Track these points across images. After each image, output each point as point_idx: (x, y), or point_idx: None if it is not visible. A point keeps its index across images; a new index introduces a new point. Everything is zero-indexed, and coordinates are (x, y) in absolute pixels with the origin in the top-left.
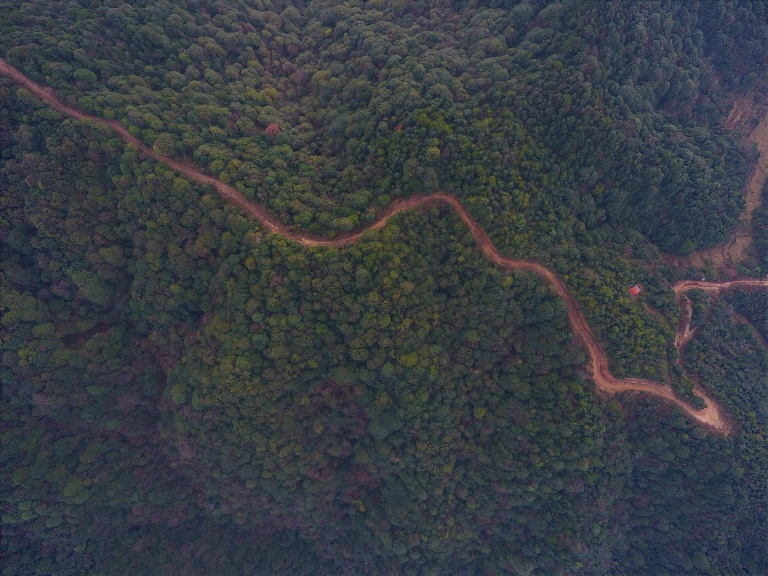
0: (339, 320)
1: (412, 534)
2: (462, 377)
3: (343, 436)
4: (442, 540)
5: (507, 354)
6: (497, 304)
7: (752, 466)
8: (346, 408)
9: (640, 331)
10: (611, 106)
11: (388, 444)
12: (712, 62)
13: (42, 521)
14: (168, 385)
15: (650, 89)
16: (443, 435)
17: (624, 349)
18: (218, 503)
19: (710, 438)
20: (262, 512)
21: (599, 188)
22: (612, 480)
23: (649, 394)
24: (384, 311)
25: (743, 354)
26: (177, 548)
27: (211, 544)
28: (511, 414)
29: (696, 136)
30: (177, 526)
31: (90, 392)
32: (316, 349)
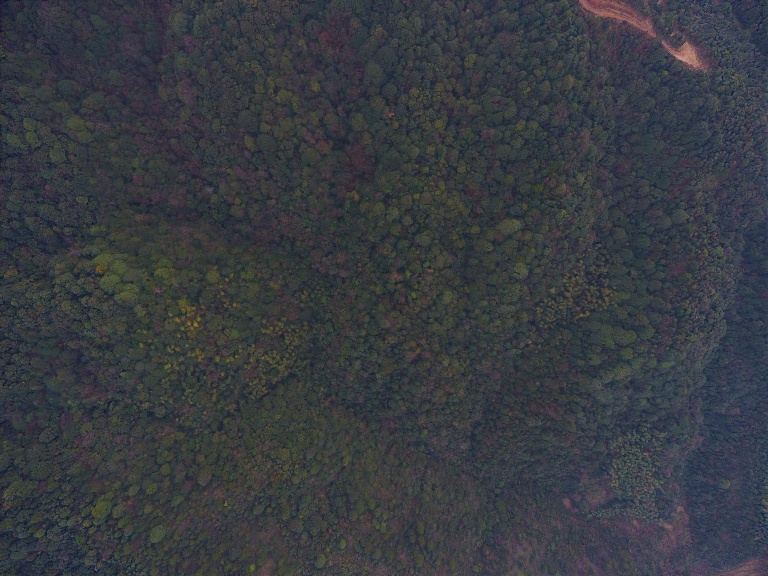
0: None
1: (405, 195)
2: (454, 24)
3: (339, 104)
4: (433, 196)
5: None
6: None
7: (727, 100)
8: (342, 62)
9: None
10: None
11: (382, 98)
12: None
13: (46, 150)
14: None
15: None
16: (435, 83)
17: None
18: (216, 186)
19: (688, 73)
20: (259, 202)
21: None
22: (596, 124)
23: (631, 25)
24: None
25: None
26: (176, 227)
27: (209, 236)
28: (500, 47)
29: None
30: (176, 214)
31: (93, 21)
32: None
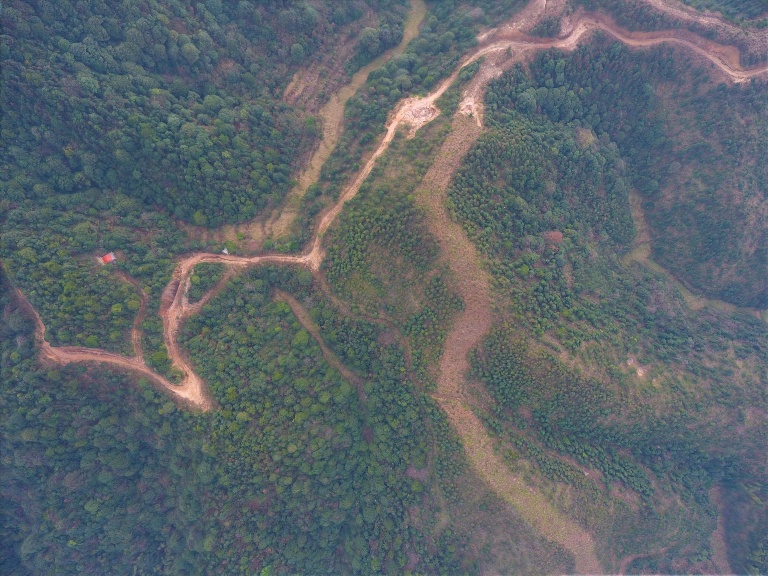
0: None
1: None
2: None
3: None
4: None
5: None
6: None
7: (226, 444)
8: None
9: (66, 297)
10: (53, 63)
11: None
12: (249, 31)
13: None
14: None
15: (124, 50)
16: None
17: (46, 314)
18: None
19: (184, 413)
20: None
21: (65, 150)
22: (98, 455)
23: (114, 365)
24: None
25: (265, 331)
26: None
27: None
28: None
29: (206, 104)
30: None
31: None
32: None
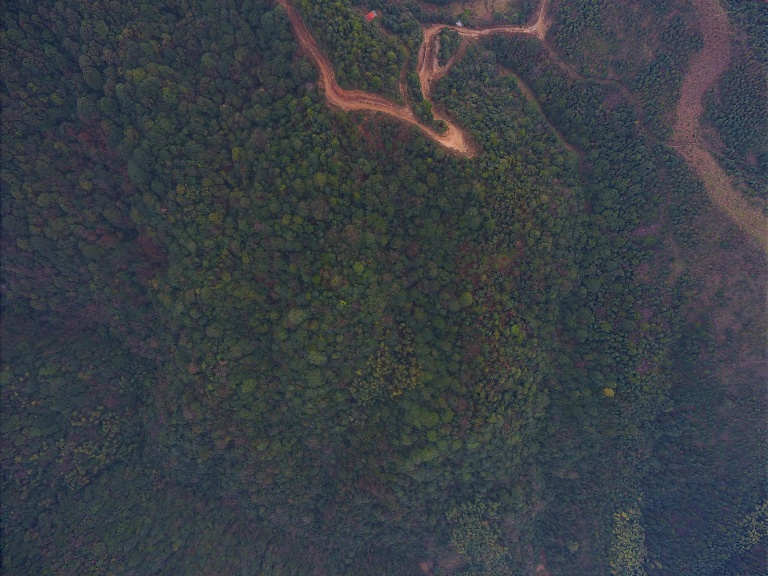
0: (61, 34)
1: (187, 290)
2: (215, 118)
3: (118, 199)
4: (214, 291)
5: (251, 85)
6: (216, 13)
7: (494, 185)
8: (109, 160)
9: None
10: None
11: (152, 194)
12: None
13: None
14: None
15: None
16: (202, 178)
17: (341, 51)
18: (9, 283)
19: (452, 159)
20: (58, 295)
21: None
22: (367, 213)
23: (387, 114)
24: (96, 15)
25: None
26: None
27: (11, 331)
28: (256, 143)
29: None
30: None
31: None
32: (54, 80)
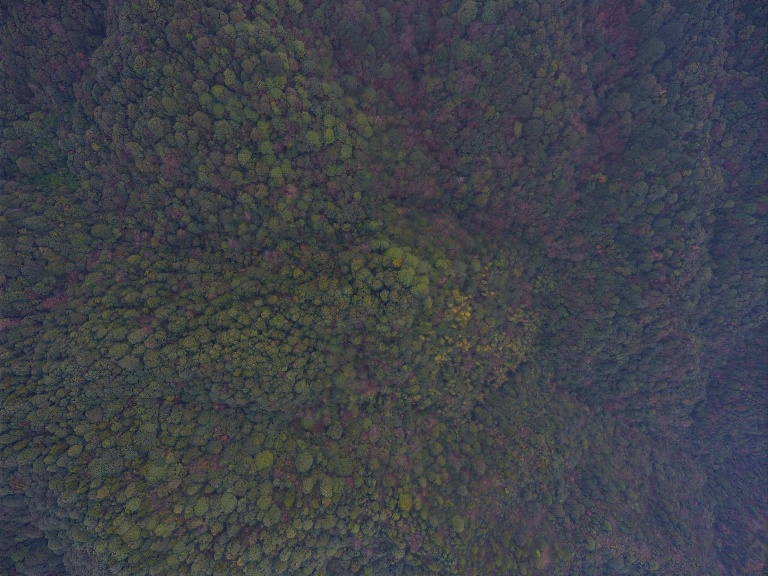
0: None
1: (673, 173)
2: None
3: (599, 85)
4: (706, 172)
5: None
6: None
7: None
8: (613, 42)
9: None
10: None
11: (654, 75)
12: None
13: (338, 146)
14: (441, 25)
15: None
16: (711, 57)
17: None
18: (467, 176)
19: None
20: (505, 190)
21: None
22: None
23: None
24: None
25: None
26: (432, 218)
27: (455, 226)
28: None
29: None
30: (424, 206)
31: (382, 14)
32: None
